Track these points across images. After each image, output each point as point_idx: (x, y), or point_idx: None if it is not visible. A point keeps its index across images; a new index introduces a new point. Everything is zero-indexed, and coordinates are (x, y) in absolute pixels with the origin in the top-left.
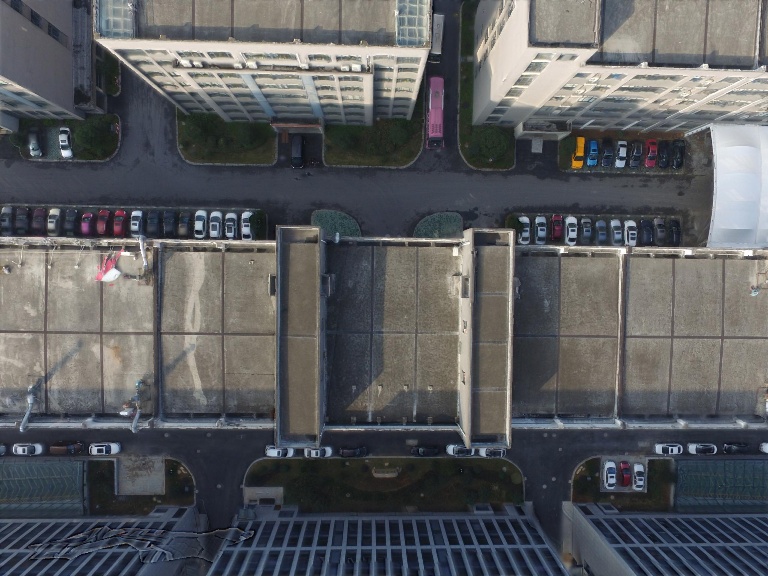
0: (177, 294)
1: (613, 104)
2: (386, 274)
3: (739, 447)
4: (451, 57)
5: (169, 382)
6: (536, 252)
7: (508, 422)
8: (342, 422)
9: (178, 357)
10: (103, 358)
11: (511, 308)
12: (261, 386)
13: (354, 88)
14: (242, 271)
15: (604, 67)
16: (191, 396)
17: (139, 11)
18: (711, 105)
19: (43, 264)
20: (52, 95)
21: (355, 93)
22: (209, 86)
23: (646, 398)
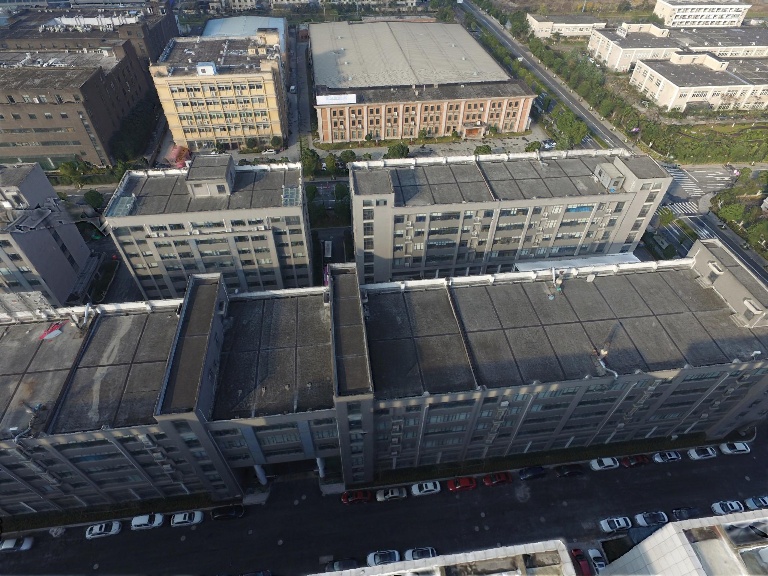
0: (102, 341)
1: (438, 250)
2: (273, 314)
3: (688, 510)
4: None
5: (69, 405)
6: None
7: (369, 374)
8: None
9: (86, 384)
10: (16, 392)
11: (360, 301)
12: (155, 400)
13: (264, 251)
14: (160, 322)
15: (405, 207)
16: (85, 415)
17: (133, 210)
18: (500, 244)
19: (1, 334)
20: (54, 288)
21: (265, 255)
22: (167, 259)
23: (500, 373)
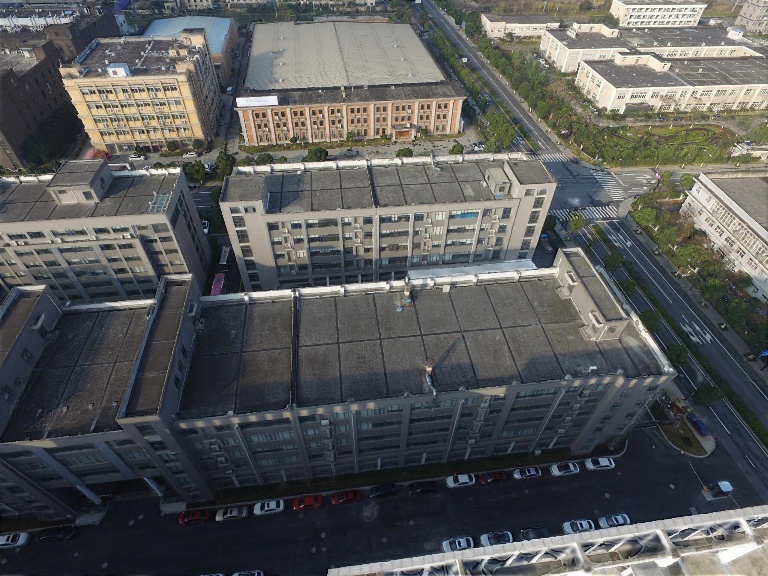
0: None
1: (323, 258)
2: (103, 327)
3: (536, 530)
4: (237, 268)
5: None
6: (230, 305)
7: (162, 393)
8: None
9: None
10: None
11: (182, 315)
12: None
13: (136, 259)
14: None
15: (276, 214)
16: None
17: None
18: (388, 251)
19: None
20: None
21: (137, 263)
22: (33, 267)
23: (320, 390)
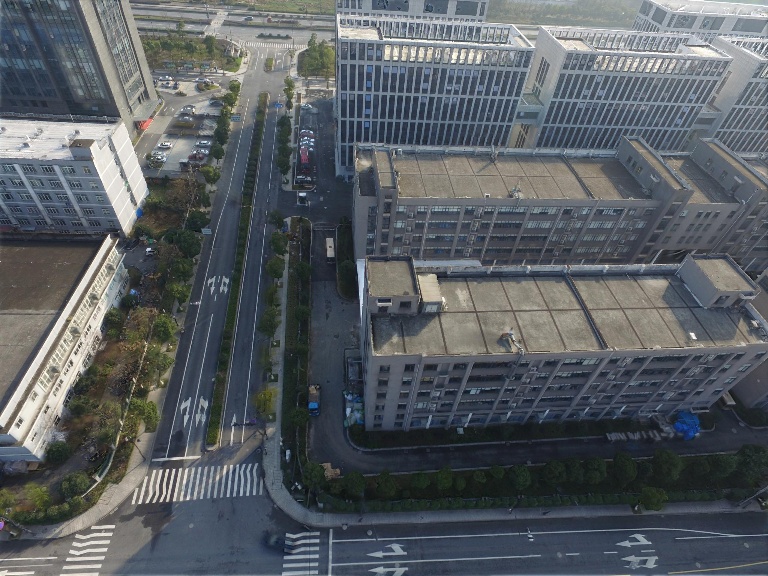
0: None
1: None
2: None
3: None
4: None
5: (765, 168)
6: None
7: None
8: (683, 157)
9: None
10: None
11: None
12: None
13: None
14: None
15: None
16: None
17: None
18: None
19: None
20: None
21: None
22: None
23: None
